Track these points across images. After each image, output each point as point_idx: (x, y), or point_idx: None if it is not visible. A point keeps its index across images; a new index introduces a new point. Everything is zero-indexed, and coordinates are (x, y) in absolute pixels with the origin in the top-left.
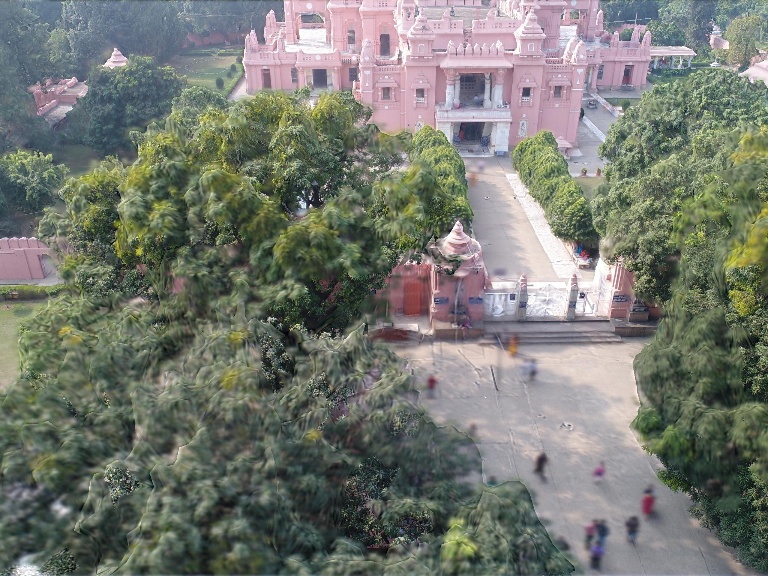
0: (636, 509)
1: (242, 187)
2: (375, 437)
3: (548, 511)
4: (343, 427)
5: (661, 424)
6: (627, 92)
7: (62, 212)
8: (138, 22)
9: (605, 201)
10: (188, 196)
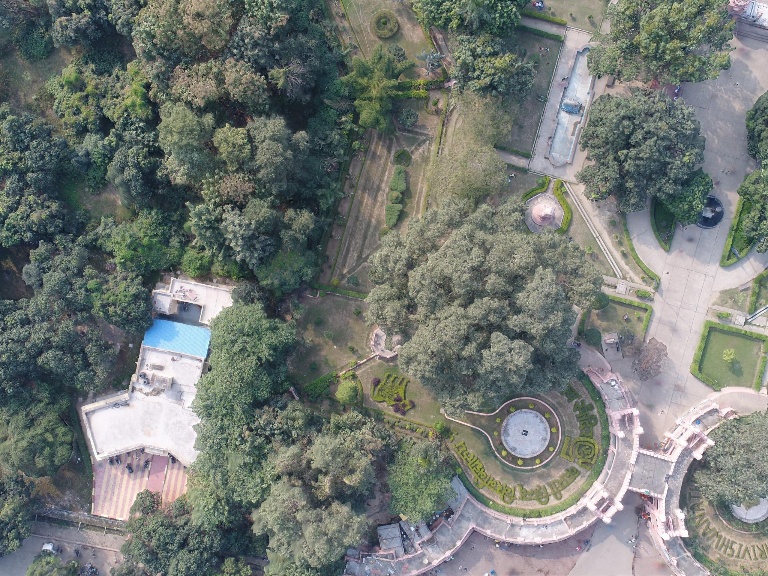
0: (738, 122)
1: (678, 53)
2: (682, 133)
3: (713, 116)
4: (677, 130)
5: (753, 118)
6: None
7: None
8: None
9: None
10: (662, 46)
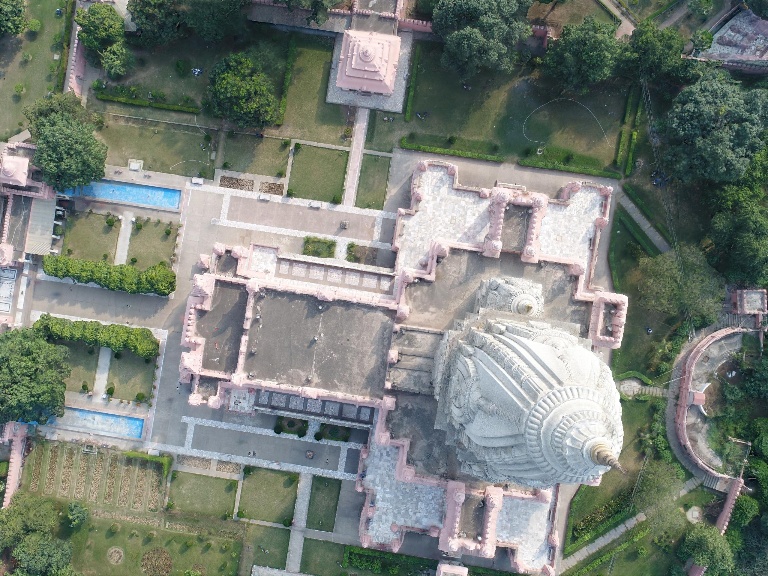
0: None
1: None
2: None
3: None
4: None
5: None
6: (357, 510)
7: (158, 68)
8: None
9: (15, 329)
10: None
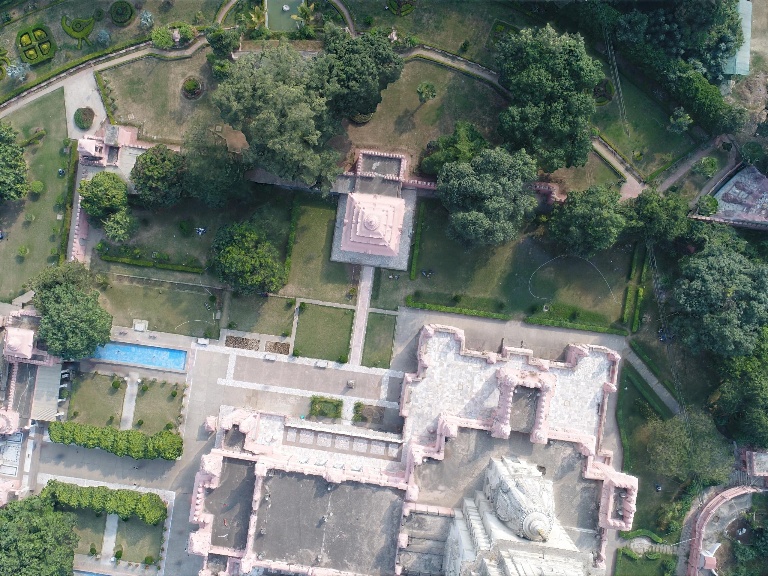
0: None
1: None
2: None
3: None
4: None
5: None
6: None
7: (162, 227)
8: (449, 228)
9: None
10: None
